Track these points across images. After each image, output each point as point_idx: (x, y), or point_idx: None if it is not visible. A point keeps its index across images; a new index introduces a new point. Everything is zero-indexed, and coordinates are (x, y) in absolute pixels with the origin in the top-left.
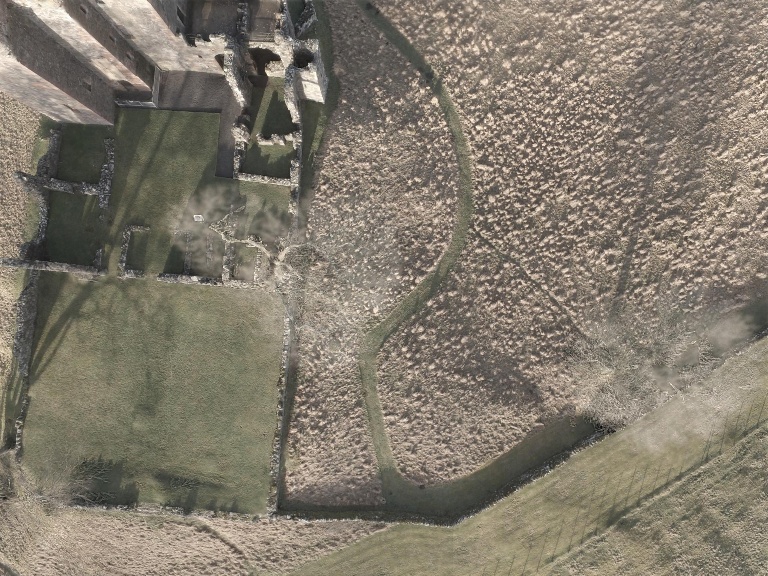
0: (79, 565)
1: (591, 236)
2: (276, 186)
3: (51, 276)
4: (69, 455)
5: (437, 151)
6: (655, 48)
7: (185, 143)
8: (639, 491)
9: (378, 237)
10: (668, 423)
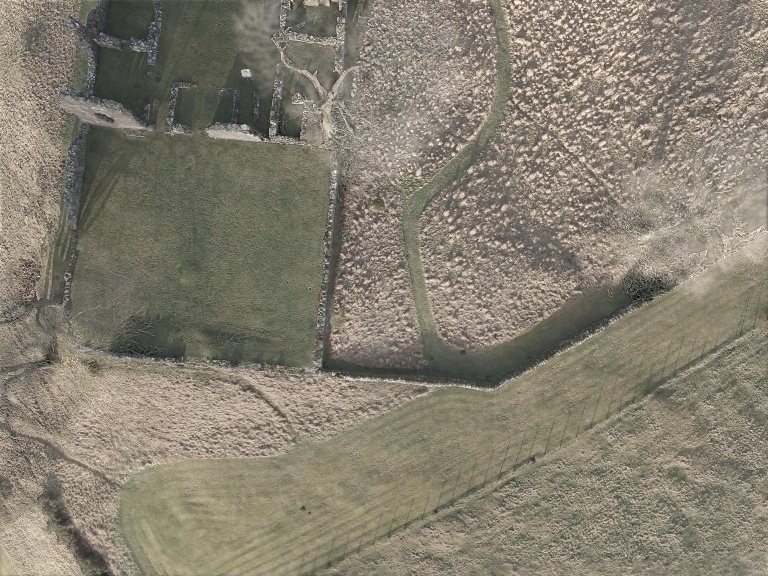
0: (122, 433)
1: (627, 111)
2: (321, 46)
3: (99, 132)
4: (117, 309)
5: (476, 23)
6: None
7: (231, 3)
8: (675, 362)
9: (420, 103)
10: (703, 296)
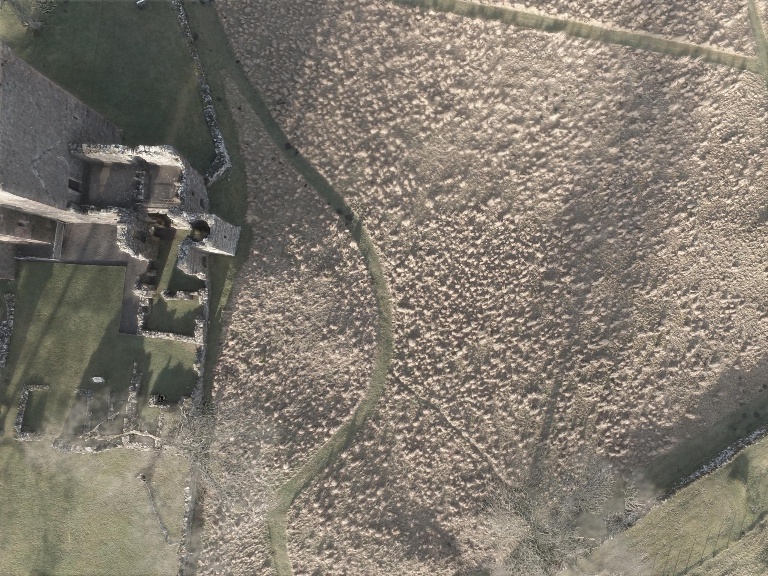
0: None
1: (514, 379)
2: (182, 342)
3: None
4: None
5: (356, 295)
6: (583, 184)
7: (88, 298)
8: None
9: (291, 389)
10: None
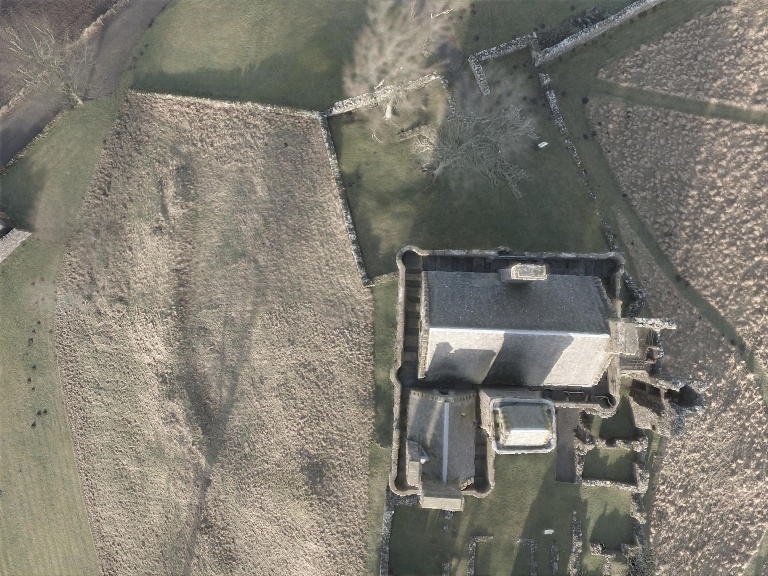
0: None
1: None
2: (617, 489)
3: None
4: None
5: (753, 426)
6: None
7: None
8: None
9: (707, 526)
10: None
